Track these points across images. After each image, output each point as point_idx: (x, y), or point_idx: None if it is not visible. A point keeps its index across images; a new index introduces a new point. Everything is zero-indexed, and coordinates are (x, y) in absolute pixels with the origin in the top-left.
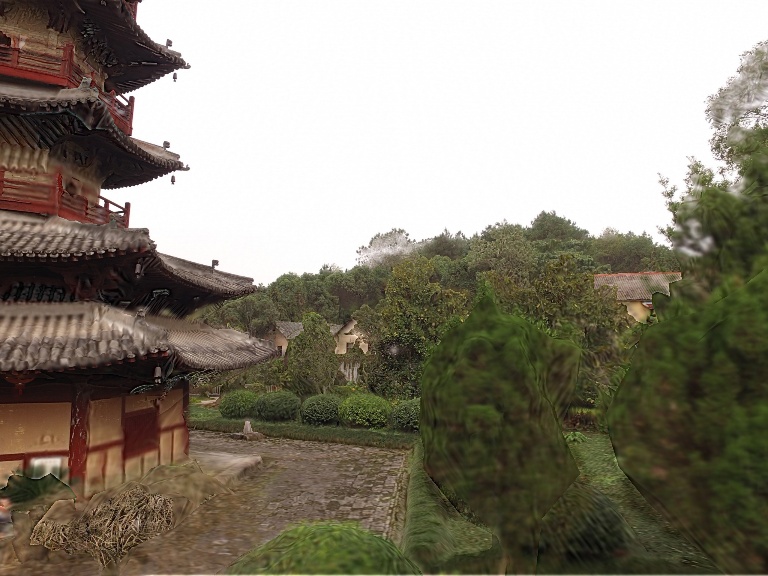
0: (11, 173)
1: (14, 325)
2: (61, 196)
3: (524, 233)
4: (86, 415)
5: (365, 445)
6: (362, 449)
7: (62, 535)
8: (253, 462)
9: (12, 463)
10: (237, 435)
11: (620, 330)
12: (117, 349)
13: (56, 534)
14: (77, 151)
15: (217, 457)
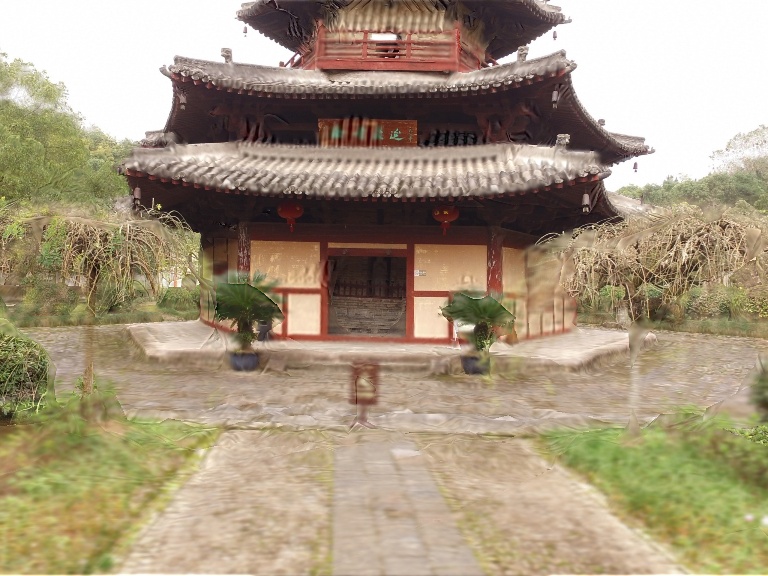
0: (416, 36)
1: (437, 167)
2: (459, 53)
3: None
4: (500, 258)
5: None
6: None
7: (610, 261)
8: (649, 338)
9: (439, 299)
10: (610, 324)
11: None
12: (542, 177)
13: (603, 259)
14: (466, 14)
15: (605, 332)
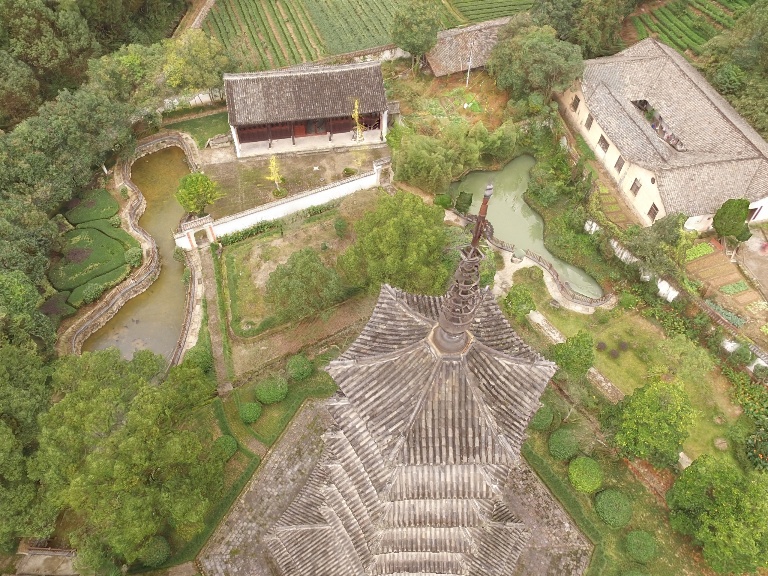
0: None
1: None
2: None
3: None
4: None
5: (573, 519)
6: (569, 528)
7: None
8: None
9: None
10: None
11: (760, 561)
12: None
13: None
14: None
15: None
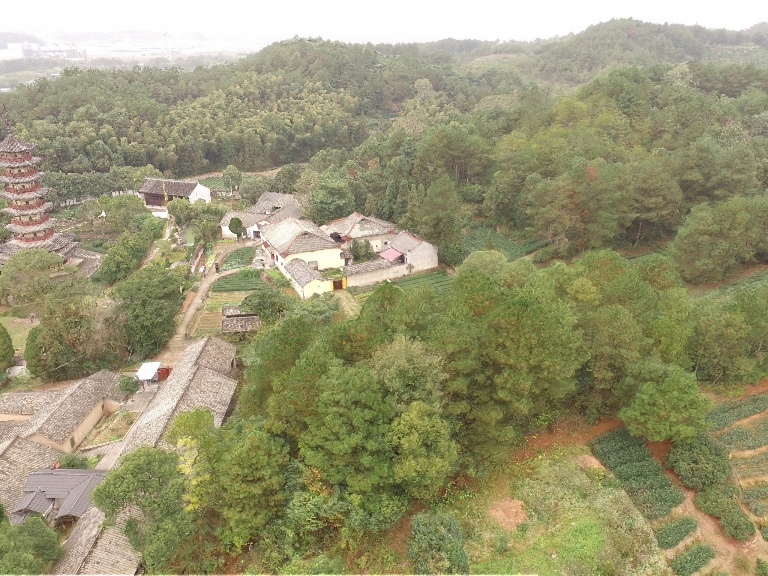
0: None
1: None
2: None
3: (421, 142)
4: None
5: None
6: None
7: None
8: None
9: None
10: None
11: None
12: None
13: None
14: None
15: None
